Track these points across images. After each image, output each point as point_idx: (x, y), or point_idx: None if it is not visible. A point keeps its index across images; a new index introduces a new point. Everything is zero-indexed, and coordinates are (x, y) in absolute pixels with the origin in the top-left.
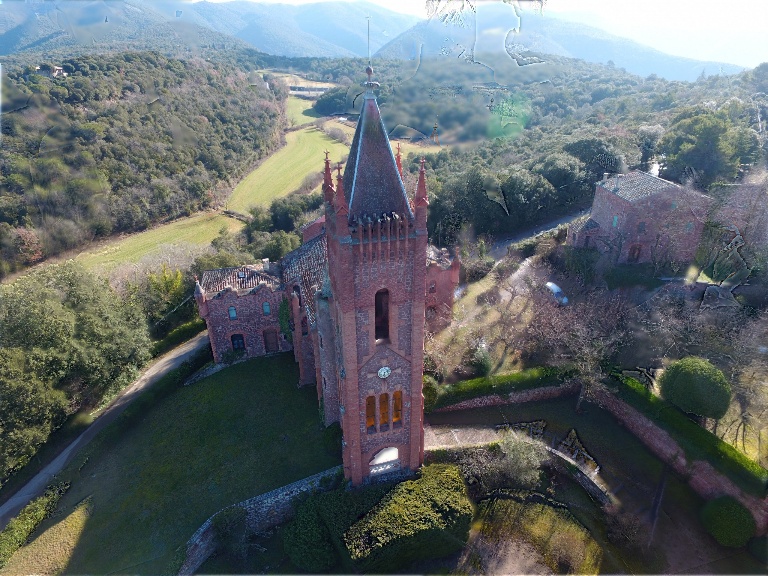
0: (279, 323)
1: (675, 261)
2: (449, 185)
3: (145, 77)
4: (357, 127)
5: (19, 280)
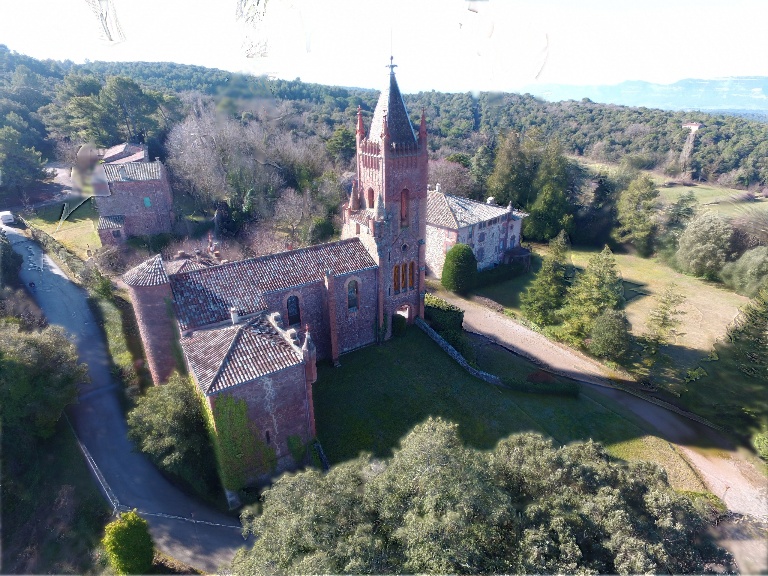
0: None
1: (220, 201)
2: None
3: None
4: (391, 91)
5: None
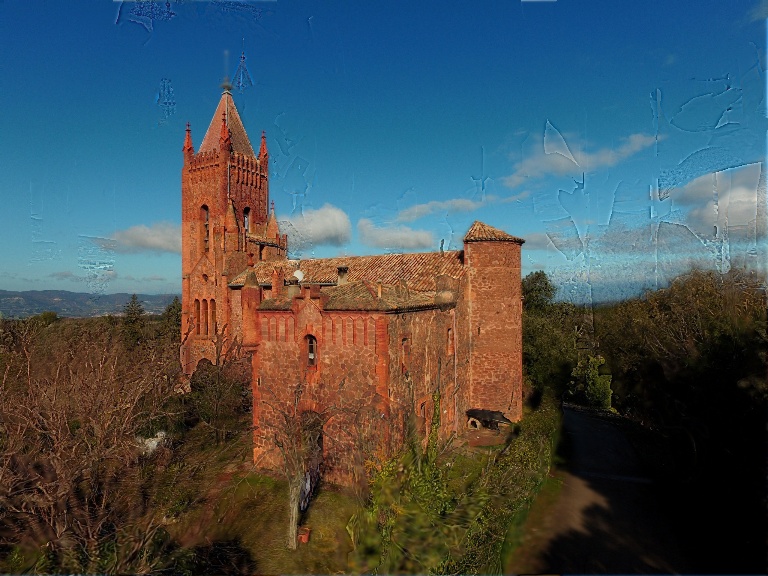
0: None
1: None
2: None
3: None
4: None
5: None
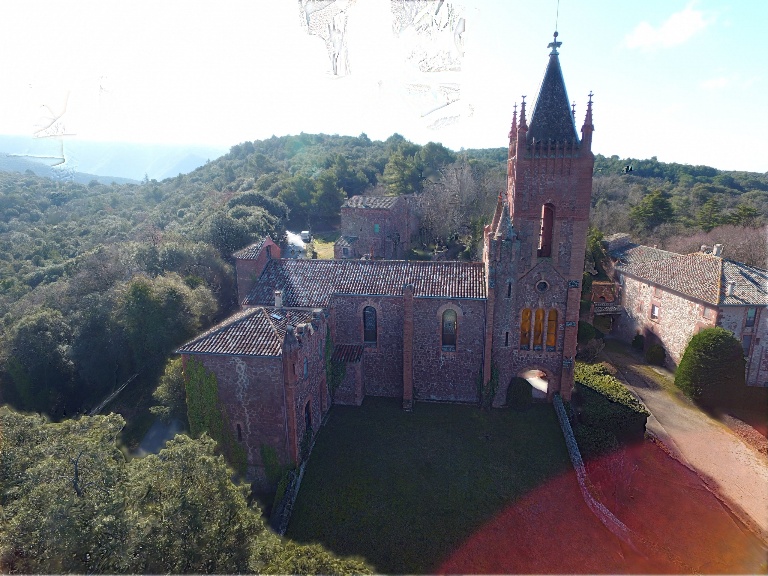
0: (325, 368)
1: (439, 237)
2: (203, 235)
3: None
4: (548, 76)
5: (62, 428)
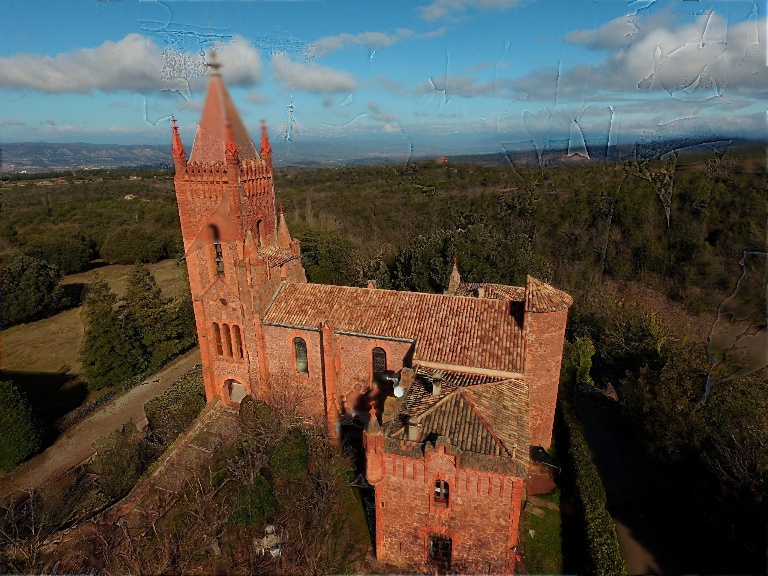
0: None
1: None
2: None
3: None
4: None
5: None
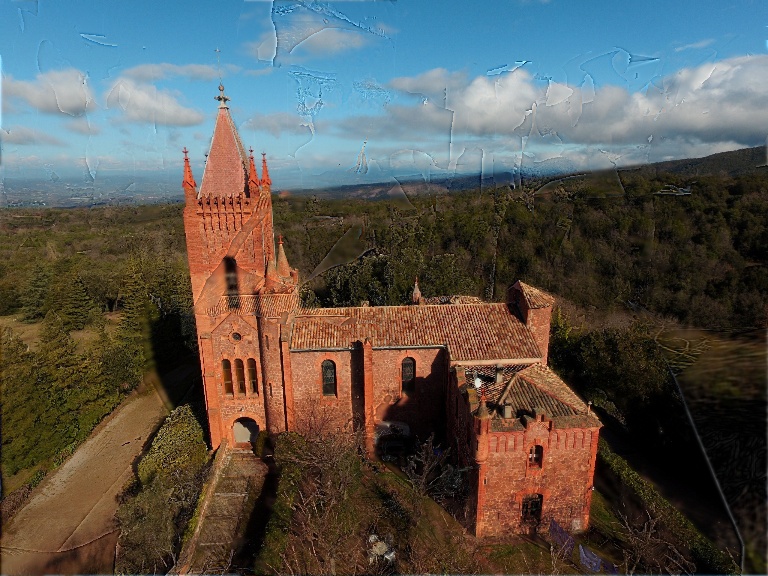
0: None
1: None
2: None
3: (767, 133)
4: None
5: None
